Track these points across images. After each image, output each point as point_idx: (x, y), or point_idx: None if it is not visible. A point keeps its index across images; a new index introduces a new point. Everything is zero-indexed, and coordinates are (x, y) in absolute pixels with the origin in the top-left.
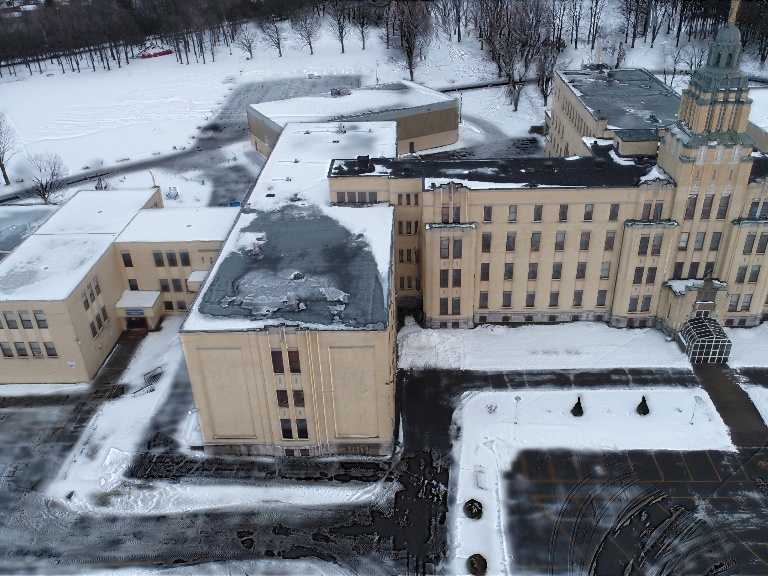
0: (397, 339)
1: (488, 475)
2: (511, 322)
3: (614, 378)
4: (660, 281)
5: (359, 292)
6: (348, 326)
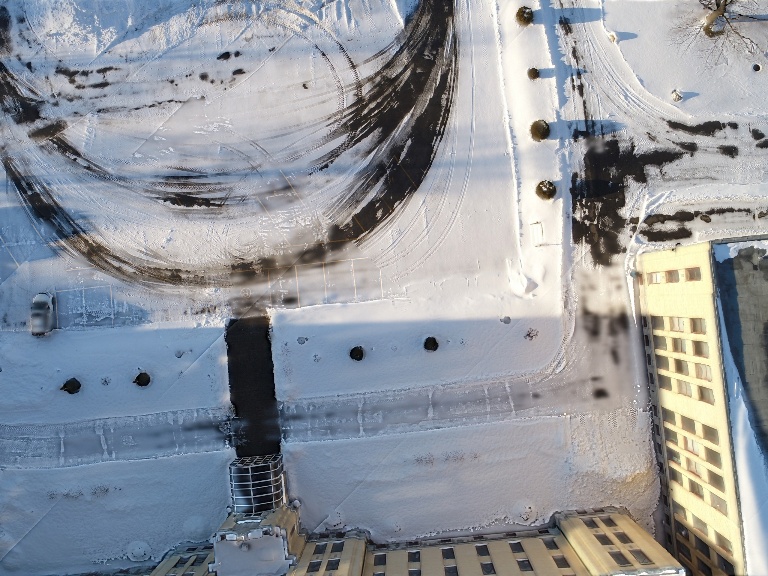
0: (661, 477)
1: (531, 245)
2: (504, 533)
3: (380, 414)
4: (302, 564)
5: (763, 338)
6: (762, 249)
